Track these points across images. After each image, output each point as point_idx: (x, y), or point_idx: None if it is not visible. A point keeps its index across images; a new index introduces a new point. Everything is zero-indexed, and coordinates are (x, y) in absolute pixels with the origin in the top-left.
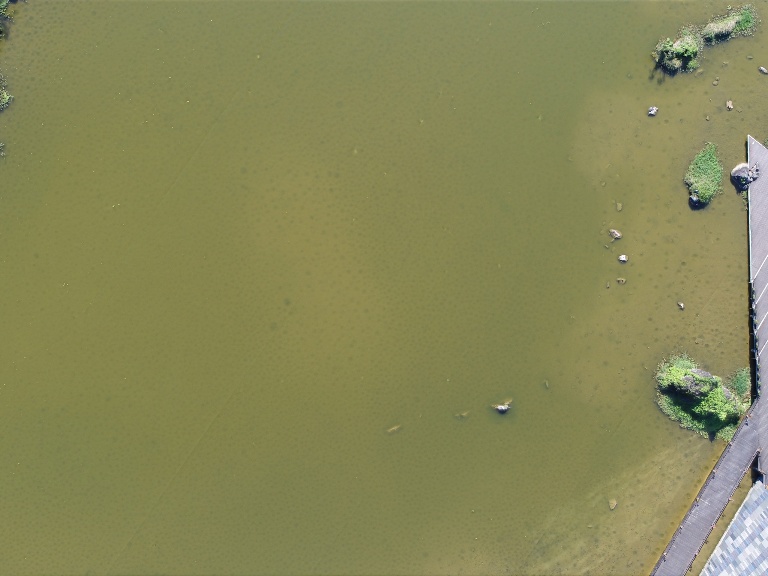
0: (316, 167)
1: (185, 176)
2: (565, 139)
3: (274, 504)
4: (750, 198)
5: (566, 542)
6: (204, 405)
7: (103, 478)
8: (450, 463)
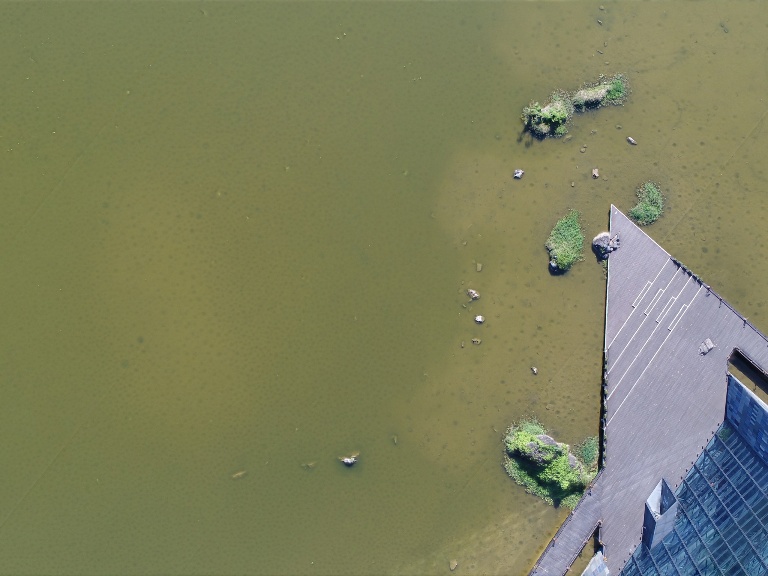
0: (179, 207)
1: (47, 207)
2: (430, 196)
3: (114, 542)
4: (609, 267)
5: None
6: (50, 438)
7: None
8: (293, 512)
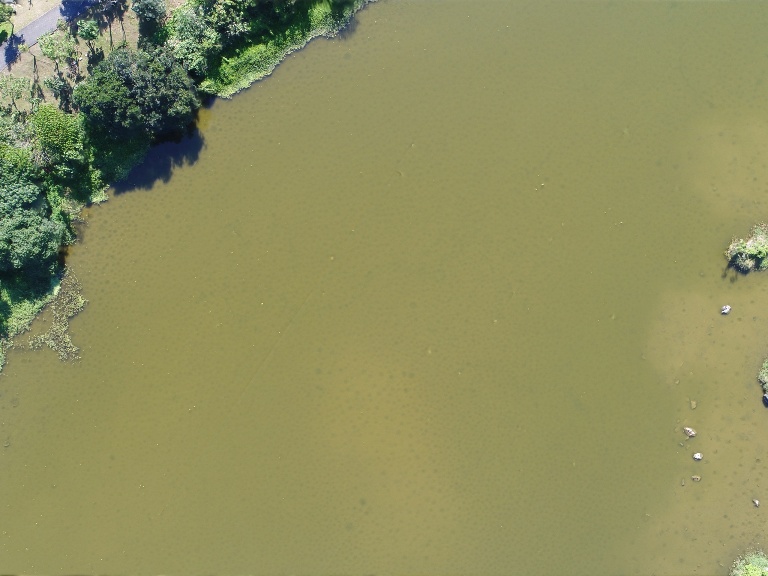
0: (390, 367)
1: (260, 377)
2: (638, 337)
3: None
4: None
5: None
6: None
7: None
8: None
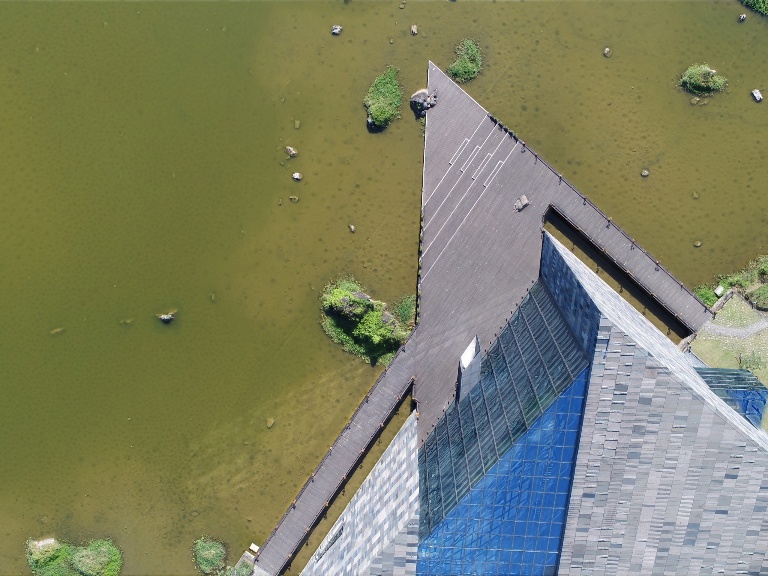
0: None
1: None
2: (248, 52)
3: None
4: (427, 124)
5: (221, 457)
6: None
7: None
8: (111, 369)
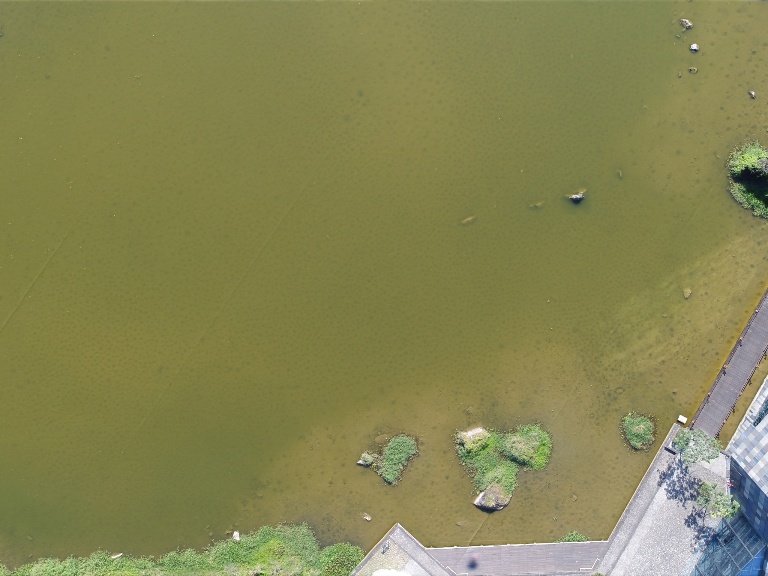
0: None
1: None
2: None
3: (349, 297)
4: None
5: (641, 332)
6: (277, 198)
7: (176, 272)
8: (525, 254)
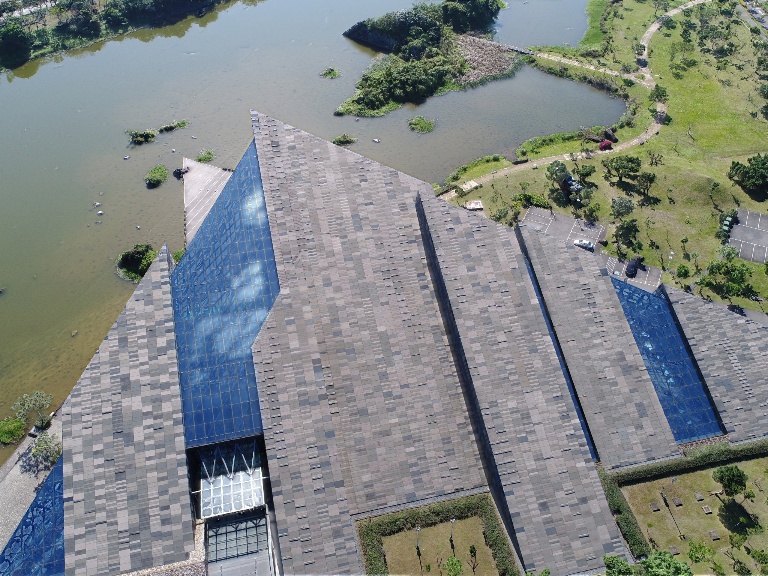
0: None
1: None
2: None
3: None
4: (184, 179)
5: (31, 362)
6: None
7: None
8: None
